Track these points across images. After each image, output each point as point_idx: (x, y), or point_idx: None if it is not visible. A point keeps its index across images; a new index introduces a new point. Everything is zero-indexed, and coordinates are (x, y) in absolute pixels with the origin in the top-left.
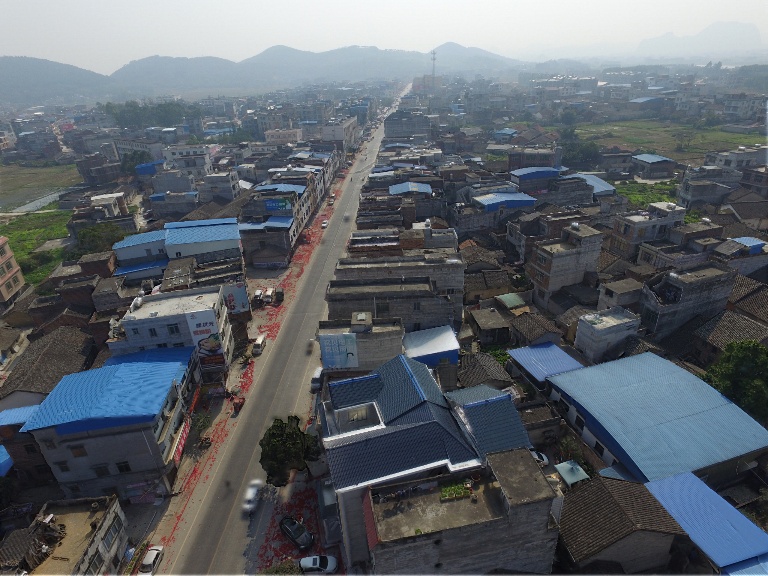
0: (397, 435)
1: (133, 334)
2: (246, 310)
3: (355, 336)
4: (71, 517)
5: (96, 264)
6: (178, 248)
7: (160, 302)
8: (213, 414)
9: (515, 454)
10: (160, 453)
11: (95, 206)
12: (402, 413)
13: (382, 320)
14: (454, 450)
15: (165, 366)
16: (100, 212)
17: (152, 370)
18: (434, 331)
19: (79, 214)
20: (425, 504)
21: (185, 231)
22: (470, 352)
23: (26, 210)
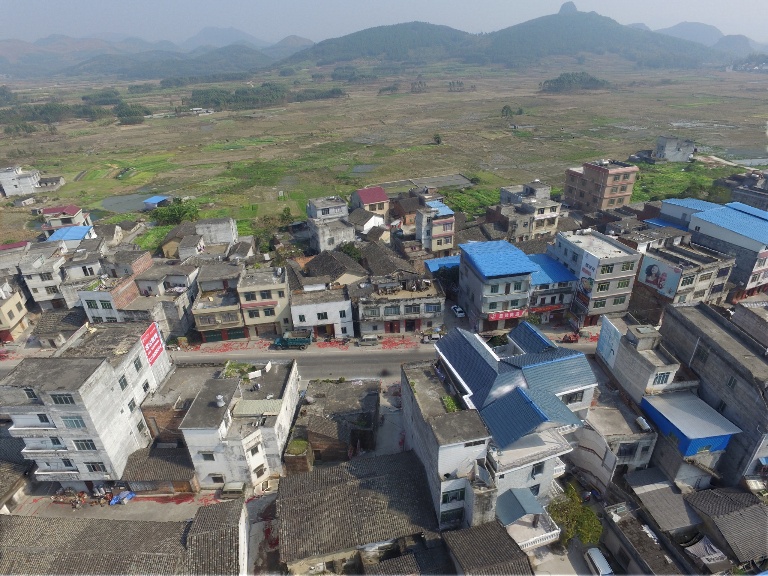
0: (478, 356)
1: (558, 246)
2: (670, 297)
3: (621, 337)
4: (433, 290)
5: (654, 210)
6: (701, 223)
7: (597, 239)
8: (553, 331)
9: (481, 427)
10: (483, 303)
11: (755, 173)
12: (509, 362)
13: (665, 352)
14: (480, 394)
15: (530, 265)
16: (753, 180)
17: (522, 262)
18: (717, 418)
19: (739, 176)
20: (437, 390)
21: (734, 214)
22: (767, 502)
23: (744, 163)
